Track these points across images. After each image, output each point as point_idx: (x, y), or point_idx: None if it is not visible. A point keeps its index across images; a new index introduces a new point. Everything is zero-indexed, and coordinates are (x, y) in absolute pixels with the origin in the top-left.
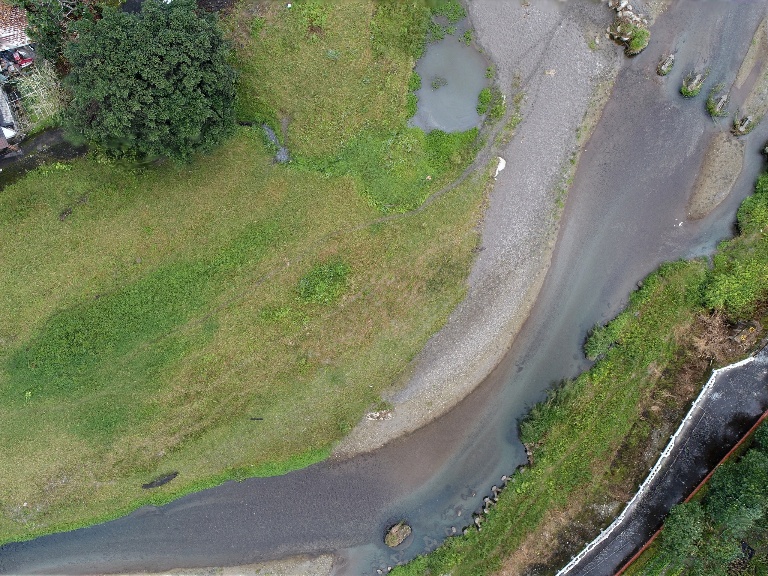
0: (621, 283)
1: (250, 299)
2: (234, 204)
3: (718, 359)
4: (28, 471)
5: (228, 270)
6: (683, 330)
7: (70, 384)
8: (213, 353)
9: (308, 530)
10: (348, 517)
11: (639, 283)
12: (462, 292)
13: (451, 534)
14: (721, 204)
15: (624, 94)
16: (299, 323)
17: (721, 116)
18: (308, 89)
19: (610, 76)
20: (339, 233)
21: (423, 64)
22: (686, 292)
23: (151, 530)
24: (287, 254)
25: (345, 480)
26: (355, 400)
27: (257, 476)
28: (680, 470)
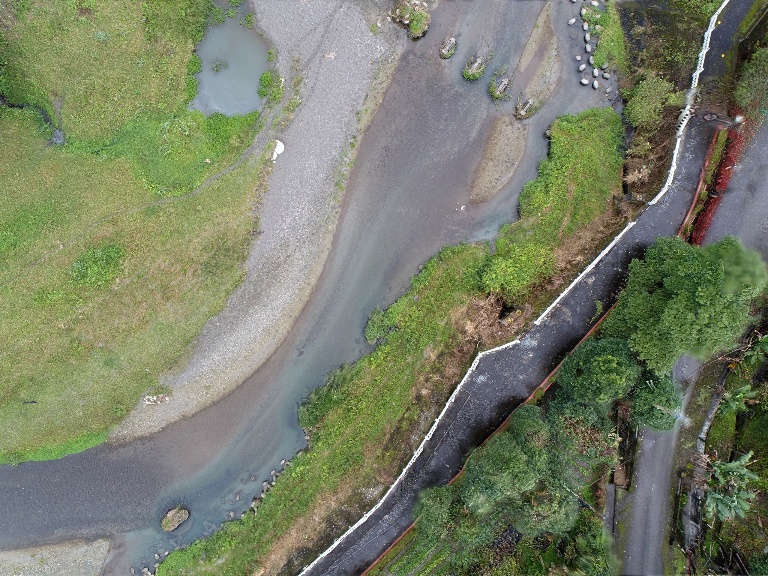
0: (403, 267)
1: (23, 282)
2: (5, 186)
3: (485, 342)
4: None
5: (1, 253)
6: (459, 314)
7: None
8: None
9: (85, 514)
10: (126, 501)
11: (419, 267)
12: (239, 275)
13: (230, 518)
14: (504, 188)
15: (406, 77)
16: (73, 306)
17: (504, 99)
18: (79, 71)
19: (392, 59)
20: (113, 216)
21: (204, 47)
22: (463, 275)
23: None
24: (61, 237)
25: (123, 464)
26: (131, 384)
27: (33, 460)
28: (444, 453)
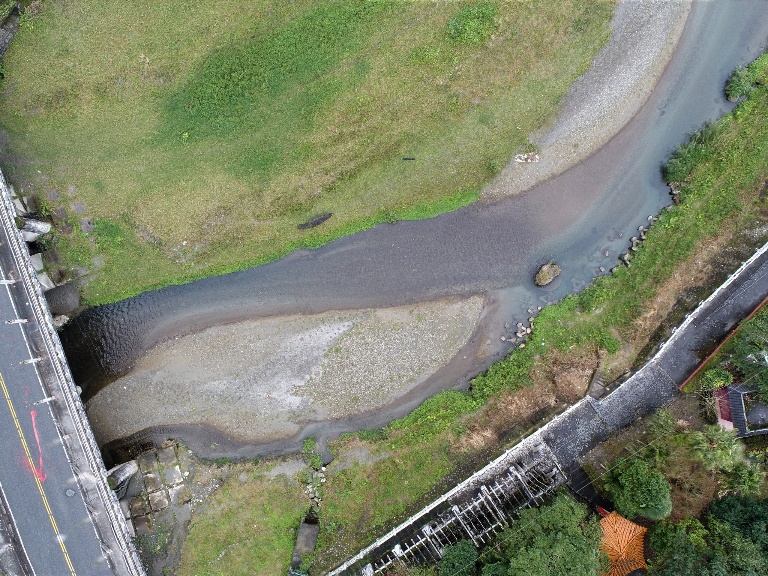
0: (760, 27)
1: (401, 40)
2: None
3: None
4: (187, 210)
5: (378, 13)
6: None
7: (226, 125)
8: (365, 94)
9: (459, 272)
10: (497, 259)
11: None
12: (606, 34)
13: (599, 274)
14: None
15: None
16: (449, 64)
17: None
18: None
19: None
20: None
21: None
22: None
23: (304, 274)
24: None
25: (494, 222)
26: (504, 141)
27: (408, 219)
28: None
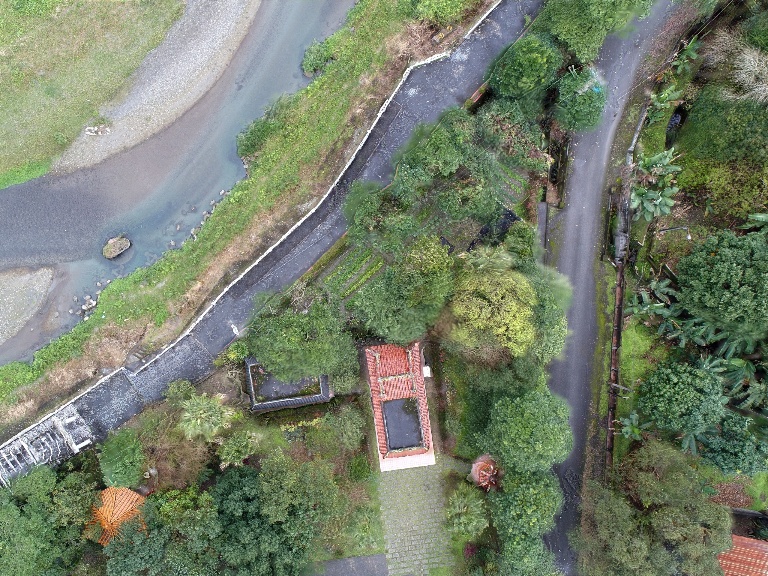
0: (340, 2)
1: None
2: None
3: (416, 57)
4: None
5: None
6: (394, 41)
7: None
8: None
9: (29, 244)
10: (69, 232)
11: (356, 0)
12: (178, 7)
13: (170, 248)
14: None
15: None
16: (14, 35)
17: None
18: None
19: None
20: None
21: None
22: (397, 4)
23: None
24: None
25: (65, 195)
26: (72, 114)
27: None
28: (377, 164)
